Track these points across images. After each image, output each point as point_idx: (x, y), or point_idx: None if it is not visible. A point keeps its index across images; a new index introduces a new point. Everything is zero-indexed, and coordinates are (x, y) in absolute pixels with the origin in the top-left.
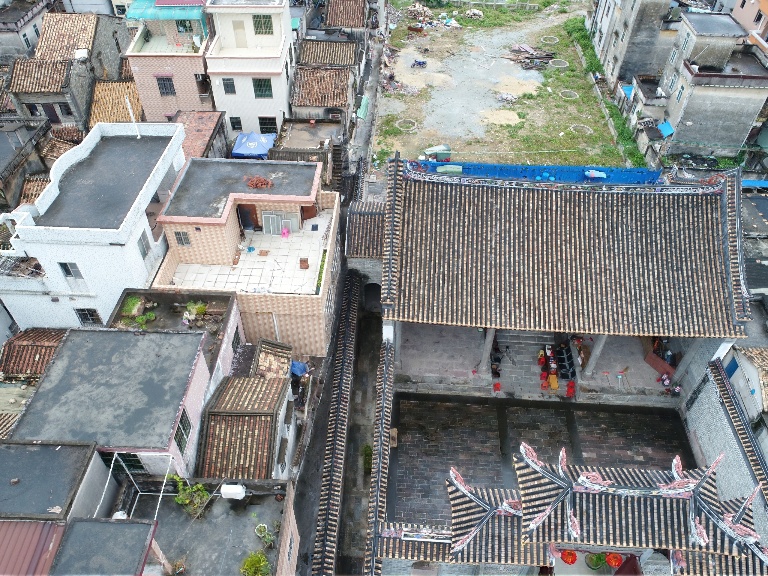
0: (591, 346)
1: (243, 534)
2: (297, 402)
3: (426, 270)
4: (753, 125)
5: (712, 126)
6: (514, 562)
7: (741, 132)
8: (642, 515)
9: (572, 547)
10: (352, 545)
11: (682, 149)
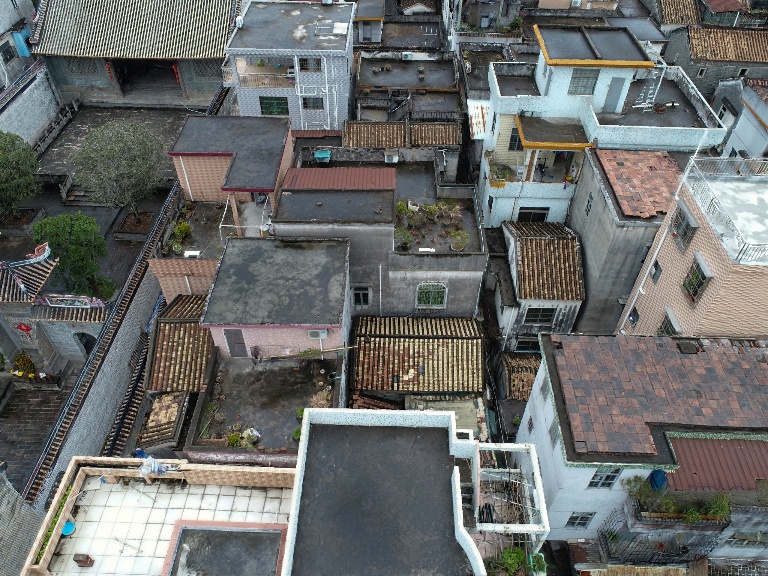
0: None
1: None
2: None
3: None
4: None
5: None
6: None
7: None
8: None
9: None
10: None
11: None
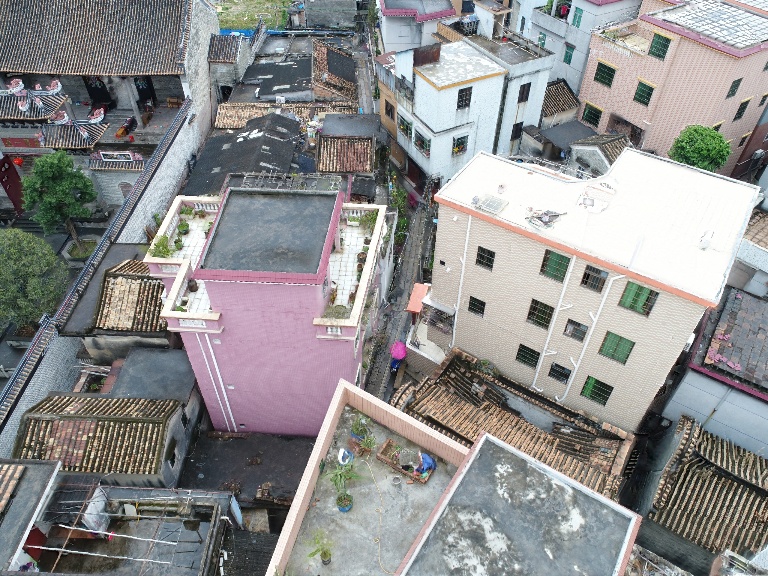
0: (157, 115)
1: None
2: None
3: (3, 43)
4: (356, 0)
5: (328, 2)
6: None
7: (351, 6)
8: (5, 104)
9: (14, 152)
10: None
11: (316, 22)
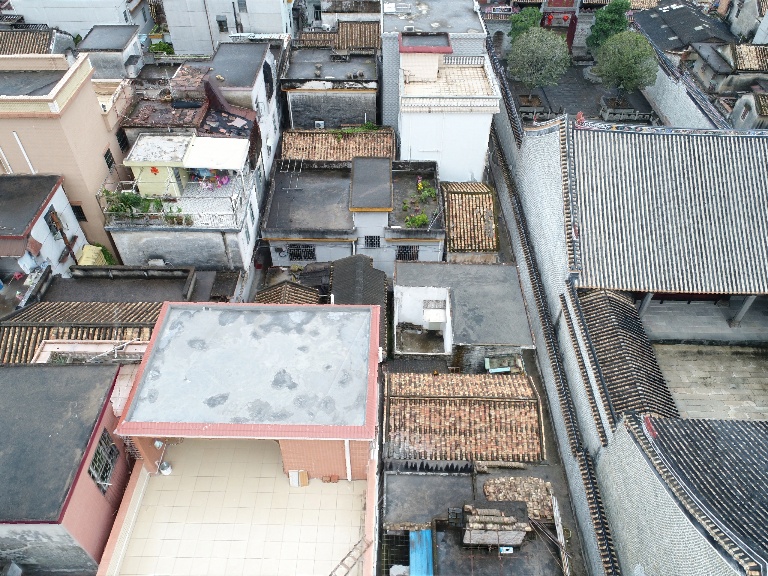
0: None
1: None
2: None
3: None
4: None
5: None
6: (532, 1)
7: None
8: None
9: (551, 11)
10: None
11: None
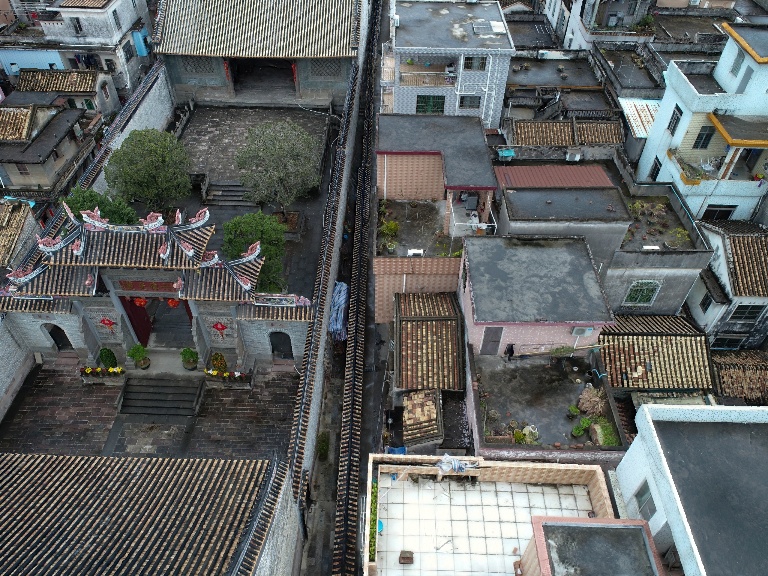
0: None
1: (404, 251)
2: (395, 430)
3: None
4: None
5: None
6: None
7: None
8: None
9: None
10: (340, 386)
11: None
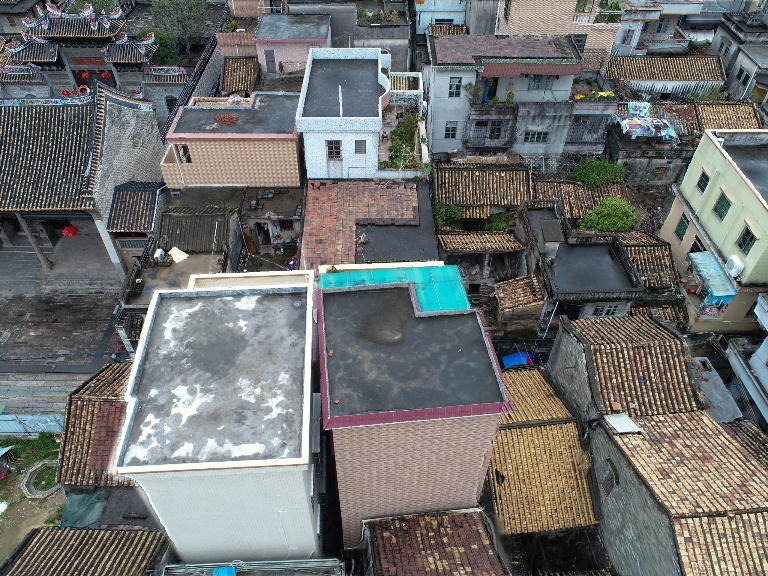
0: None
1: None
2: None
3: None
4: None
5: None
6: None
7: None
8: None
9: None
10: None
11: None
